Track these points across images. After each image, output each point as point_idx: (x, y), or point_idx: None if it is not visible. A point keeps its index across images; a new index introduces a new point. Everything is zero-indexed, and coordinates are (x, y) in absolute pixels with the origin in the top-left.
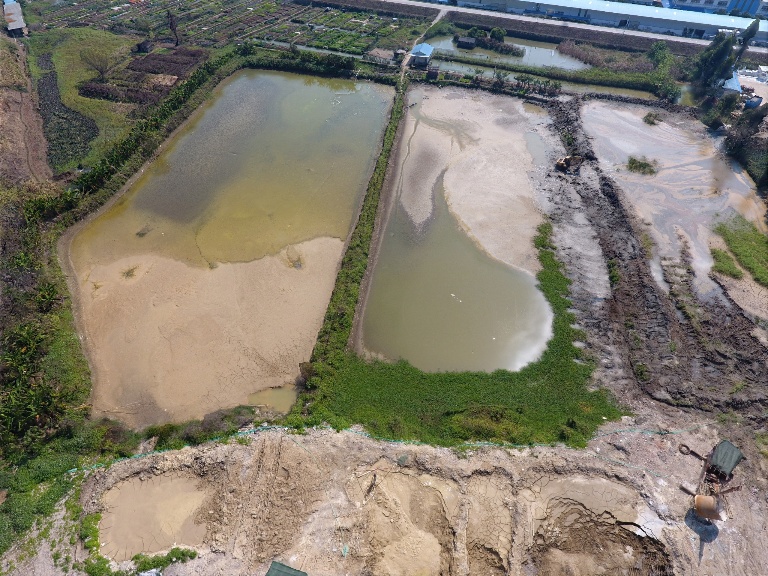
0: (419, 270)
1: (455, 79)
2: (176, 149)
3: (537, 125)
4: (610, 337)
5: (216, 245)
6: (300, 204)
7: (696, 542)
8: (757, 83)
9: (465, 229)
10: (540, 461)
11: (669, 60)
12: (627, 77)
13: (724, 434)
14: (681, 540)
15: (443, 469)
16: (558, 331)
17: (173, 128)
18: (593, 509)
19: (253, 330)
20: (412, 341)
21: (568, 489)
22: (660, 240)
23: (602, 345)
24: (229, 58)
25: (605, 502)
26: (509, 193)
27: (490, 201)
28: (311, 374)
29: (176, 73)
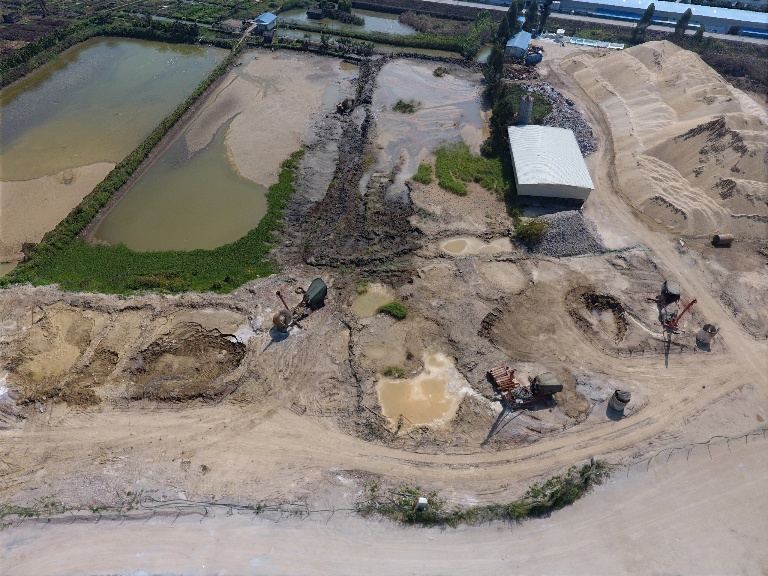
0: (172, 185)
1: (287, 43)
2: (4, 99)
3: (343, 79)
4: (303, 227)
5: (4, 169)
6: (95, 139)
7: (267, 342)
8: (552, 44)
9: (229, 156)
10: (182, 300)
11: (484, 26)
12: (440, 40)
13: (337, 281)
14: (257, 341)
15: (103, 306)
16: (262, 223)
17: (7, 83)
18: (206, 327)
19: (5, 226)
20: (139, 233)
21: (195, 317)
22: (383, 159)
23: (292, 232)
24: (84, 26)
25: (218, 323)
26: (284, 130)
27: (264, 135)
28: (30, 250)
29: (31, 39)
